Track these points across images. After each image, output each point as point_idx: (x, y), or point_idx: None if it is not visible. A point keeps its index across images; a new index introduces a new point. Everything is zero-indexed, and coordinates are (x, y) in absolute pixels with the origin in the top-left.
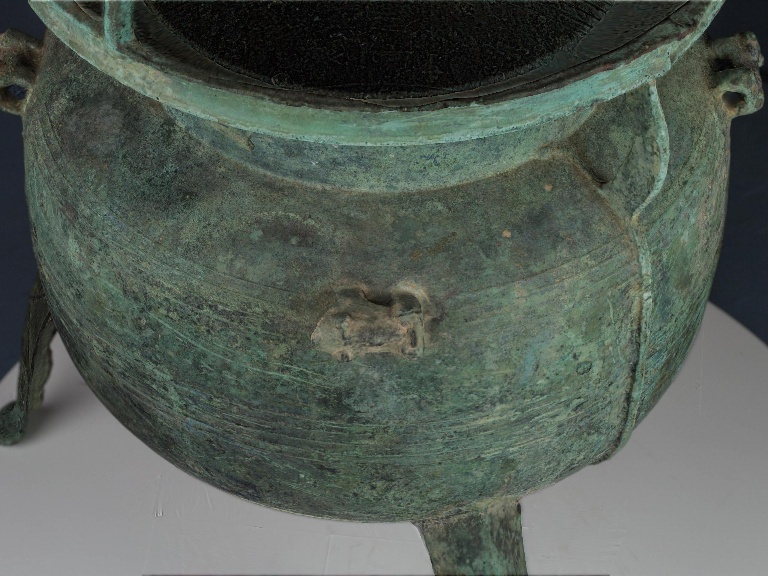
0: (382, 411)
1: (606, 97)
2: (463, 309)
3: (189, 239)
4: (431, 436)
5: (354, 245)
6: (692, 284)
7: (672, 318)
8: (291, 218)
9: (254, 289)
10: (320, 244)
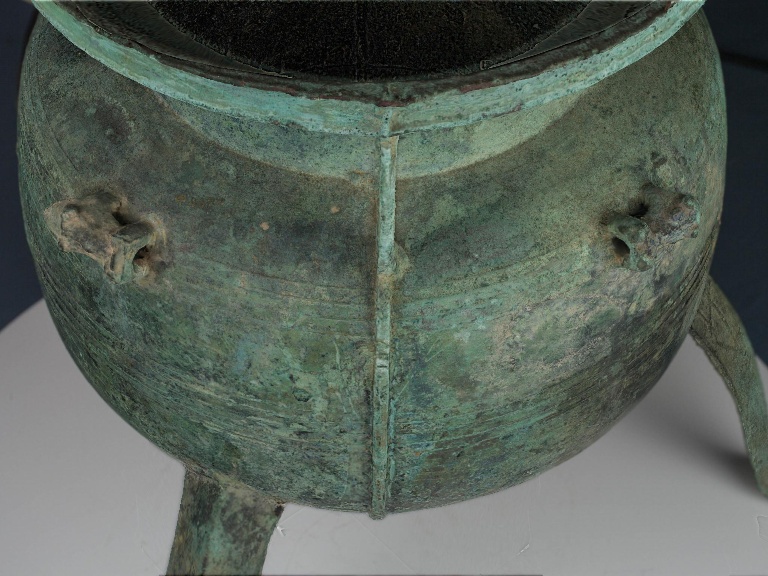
0: (118, 325)
1: (305, 126)
2: (188, 268)
3: (54, 88)
4: (157, 375)
5: (144, 162)
6: (478, 392)
7: (436, 409)
8: (122, 112)
9: (60, 155)
10: (122, 146)
